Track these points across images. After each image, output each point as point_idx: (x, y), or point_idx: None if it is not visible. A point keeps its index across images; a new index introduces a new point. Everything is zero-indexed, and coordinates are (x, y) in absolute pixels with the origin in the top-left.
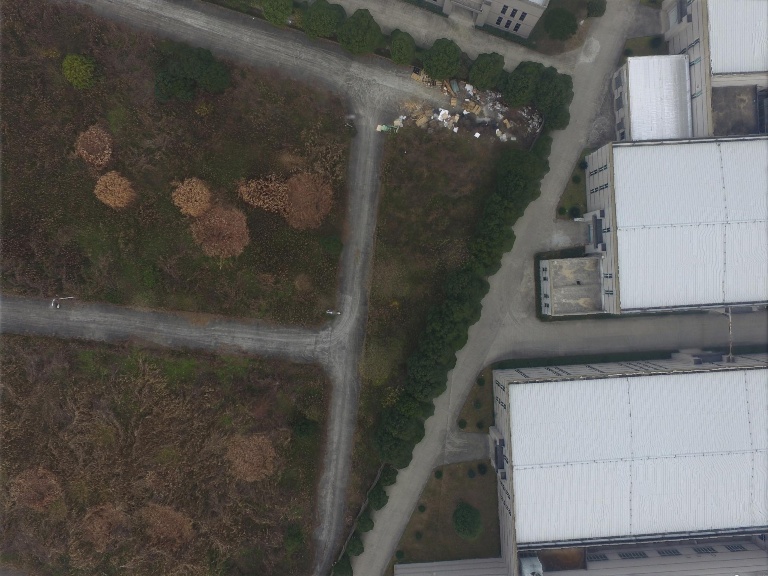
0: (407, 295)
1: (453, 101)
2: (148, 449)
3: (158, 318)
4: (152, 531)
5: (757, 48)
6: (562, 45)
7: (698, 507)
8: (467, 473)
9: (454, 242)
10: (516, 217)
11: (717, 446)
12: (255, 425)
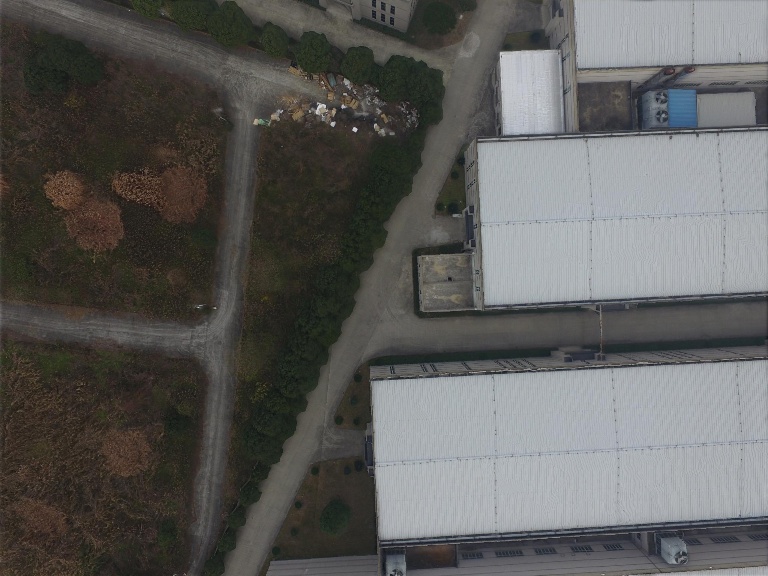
0: (281, 290)
1: (330, 95)
2: (20, 443)
3: (33, 311)
4: (26, 525)
5: (625, 43)
6: (441, 39)
7: (559, 505)
8: (343, 470)
9: (327, 237)
10: (387, 212)
11: (581, 444)
12: (130, 420)
